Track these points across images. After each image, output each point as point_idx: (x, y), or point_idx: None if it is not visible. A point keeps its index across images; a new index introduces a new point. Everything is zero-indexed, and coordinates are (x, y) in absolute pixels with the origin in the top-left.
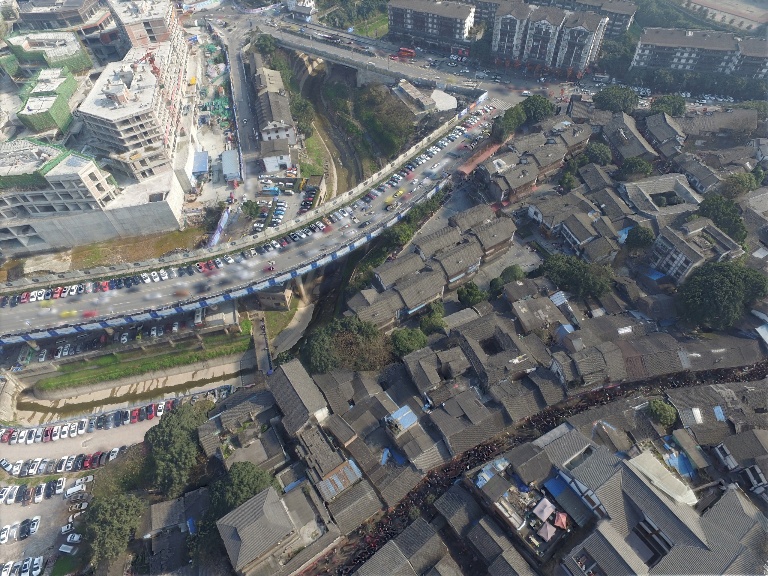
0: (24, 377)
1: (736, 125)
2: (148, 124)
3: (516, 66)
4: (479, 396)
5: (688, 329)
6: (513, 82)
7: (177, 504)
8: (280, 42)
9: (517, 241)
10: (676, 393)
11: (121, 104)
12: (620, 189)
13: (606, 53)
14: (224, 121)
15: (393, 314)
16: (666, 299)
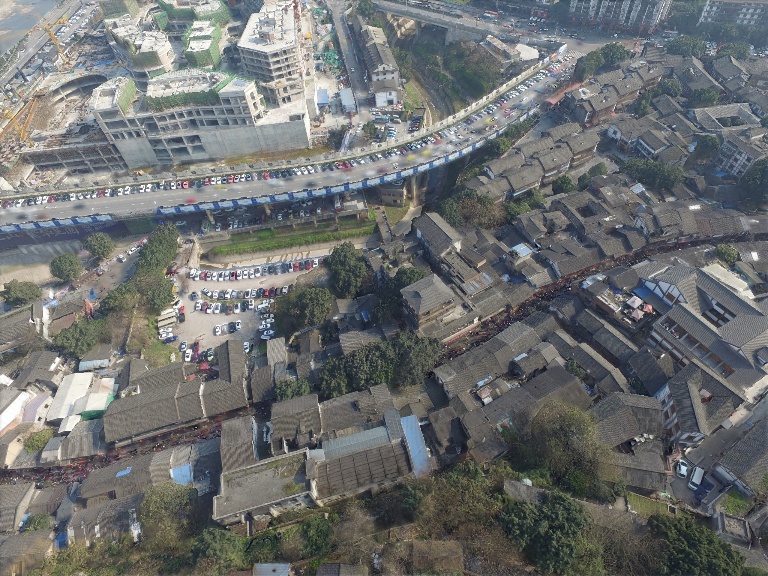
0: (204, 243)
1: None
2: (291, 58)
3: (592, 24)
4: (578, 243)
5: (748, 209)
6: (589, 38)
7: (353, 302)
8: (378, 7)
9: (598, 155)
10: (738, 244)
11: (271, 41)
12: (689, 115)
13: (676, 12)
14: (335, 69)
15: (503, 193)
16: (730, 186)
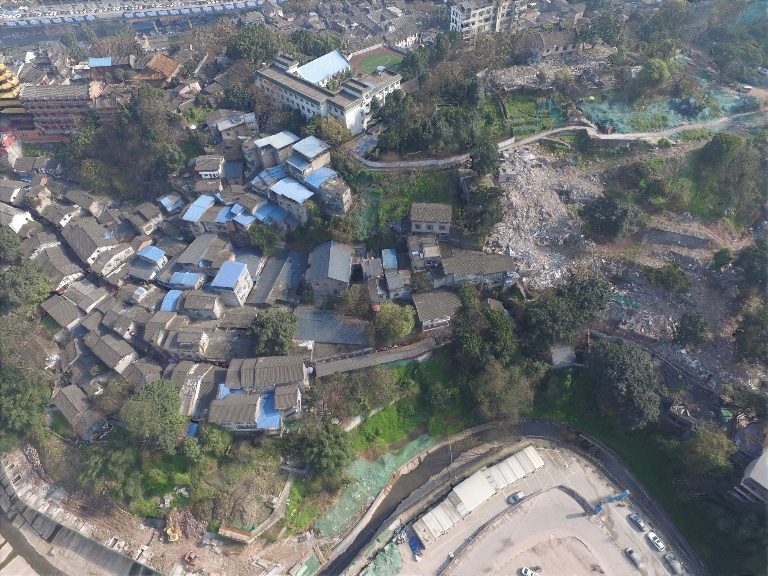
0: (152, 42)
1: None
2: None
3: None
4: None
5: None
6: None
7: None
8: None
9: None
10: None
11: None
12: None
13: None
14: None
15: (318, 1)
16: None
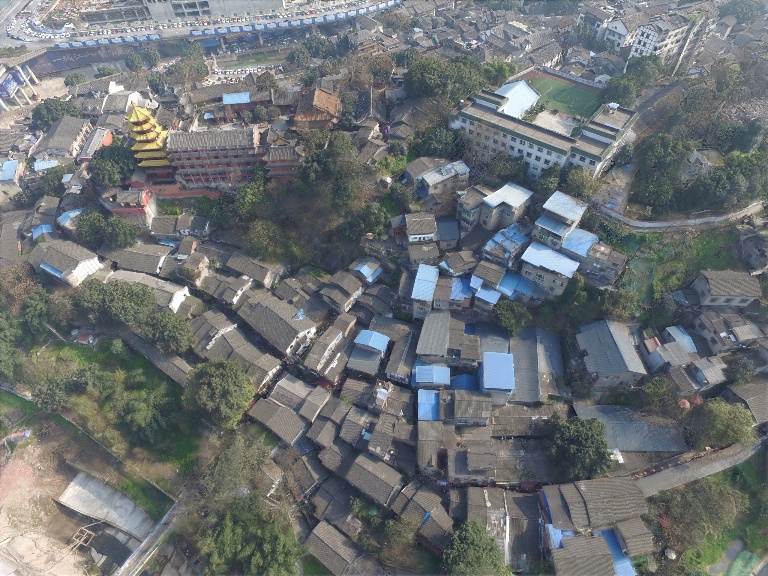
0: (220, 62)
1: None
2: None
3: None
4: None
5: None
6: None
7: (321, 60)
8: None
9: (475, 6)
10: None
11: None
12: None
13: None
14: None
15: (410, 15)
16: (541, 6)
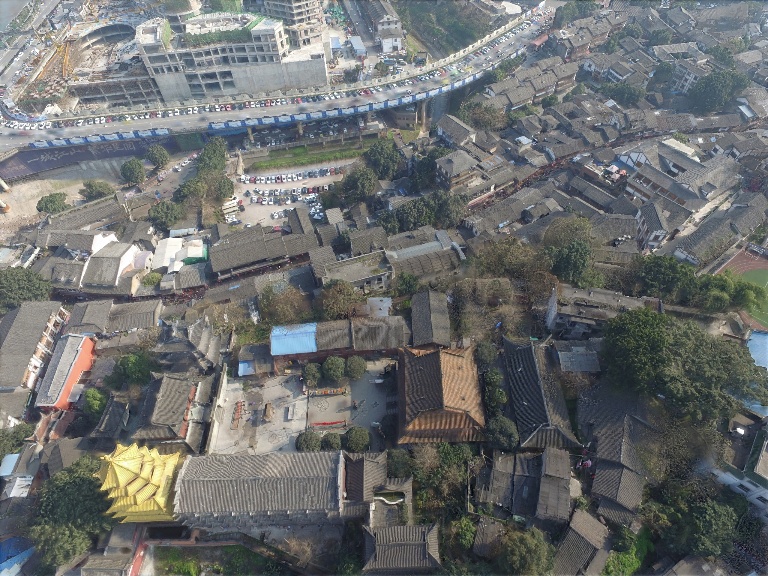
0: (246, 158)
1: (733, 14)
2: (310, 4)
3: None
4: None
5: (696, 115)
6: None
7: (391, 183)
8: None
9: (576, 84)
10: None
11: None
12: (649, 51)
13: None
14: (341, 22)
15: (503, 106)
16: None
